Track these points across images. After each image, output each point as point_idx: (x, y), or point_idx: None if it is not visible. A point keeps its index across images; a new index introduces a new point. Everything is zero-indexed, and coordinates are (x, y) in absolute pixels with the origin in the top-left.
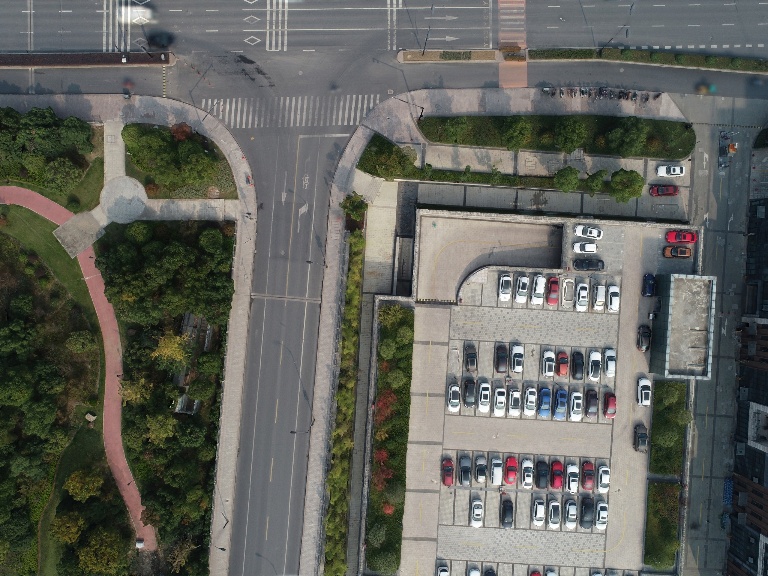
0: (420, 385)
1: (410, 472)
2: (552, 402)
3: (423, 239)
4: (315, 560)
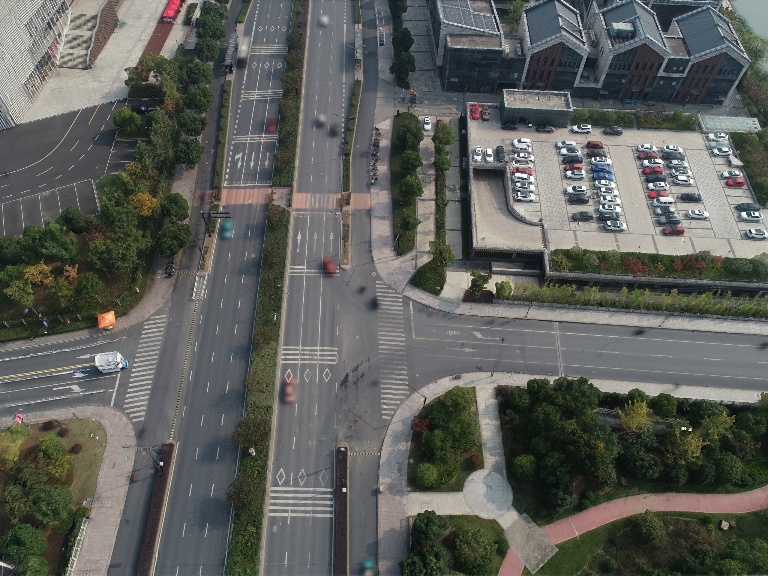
0: (611, 248)
1: None
2: None
3: None
4: None
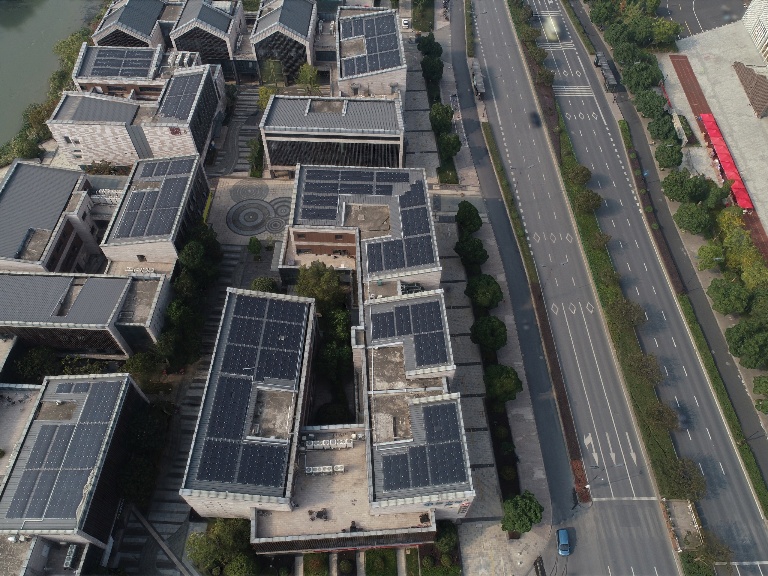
0: None
1: None
2: None
3: None
4: None
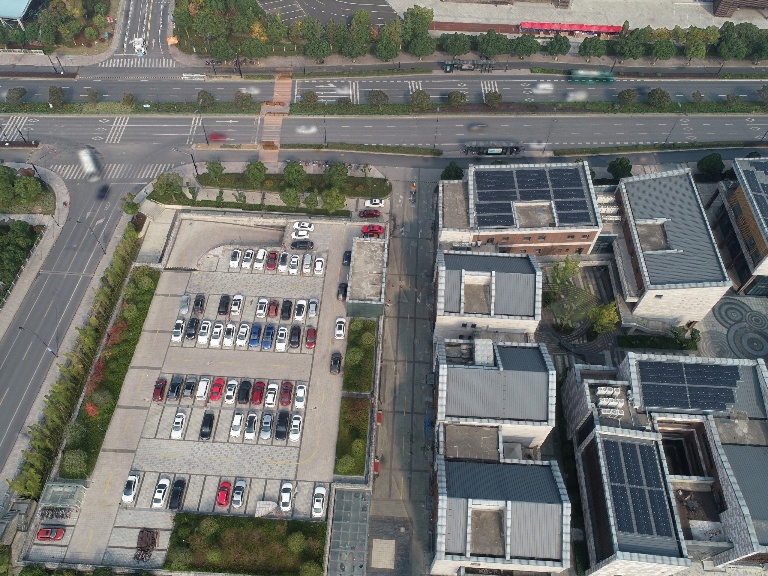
0: (153, 324)
1: (126, 391)
2: None
3: (180, 232)
4: (13, 479)
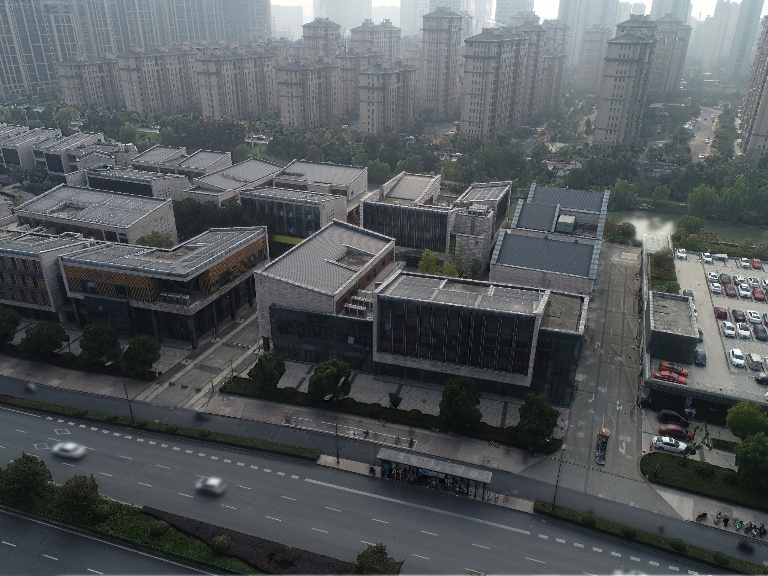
0: None
1: None
2: None
3: None
4: None
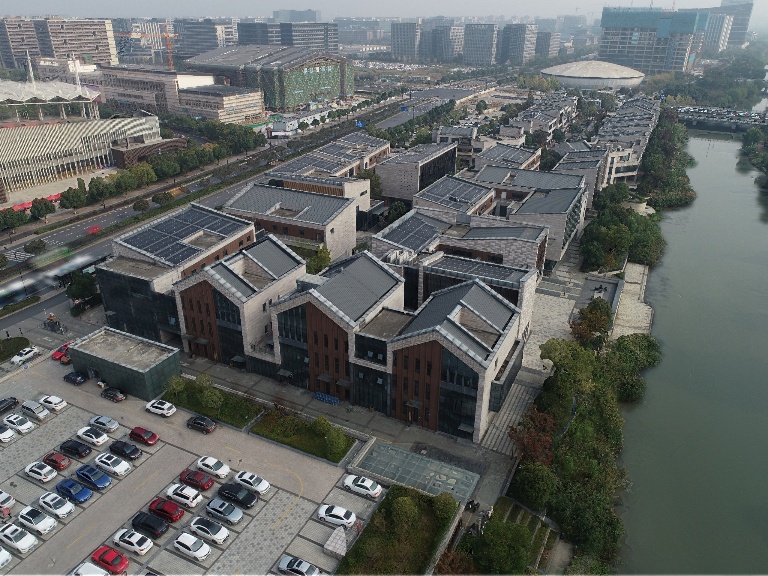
0: None
1: None
2: (85, 486)
3: None
4: None
